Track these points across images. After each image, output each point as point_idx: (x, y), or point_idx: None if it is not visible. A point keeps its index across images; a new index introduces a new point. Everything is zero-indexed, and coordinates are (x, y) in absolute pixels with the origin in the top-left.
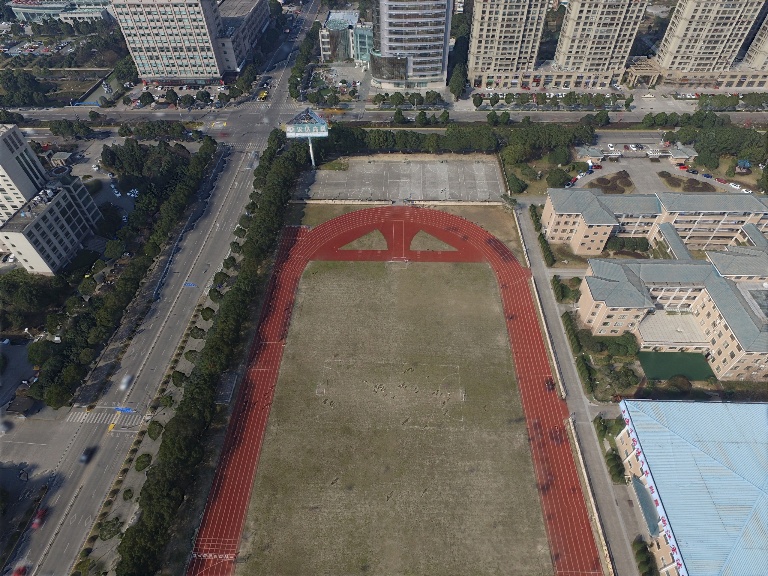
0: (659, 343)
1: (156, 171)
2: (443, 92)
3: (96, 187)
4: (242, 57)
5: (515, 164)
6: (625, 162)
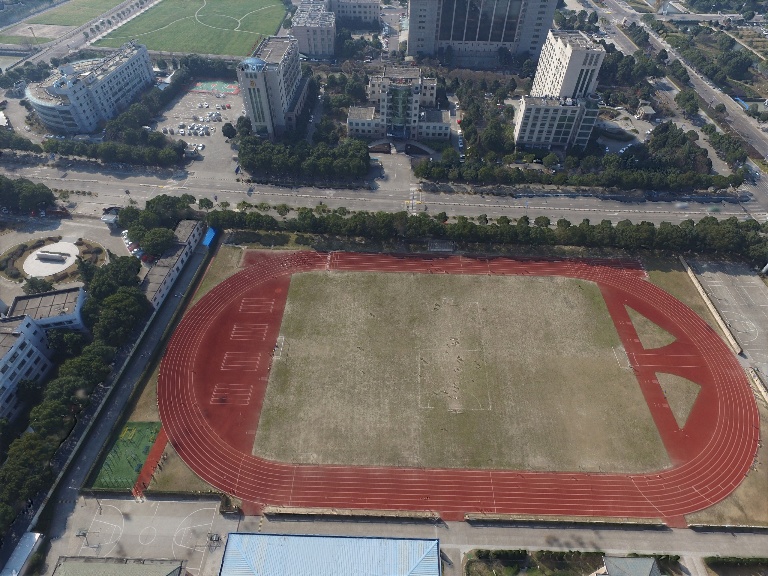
0: None
1: None
2: None
3: (624, 138)
4: None
5: None
6: None
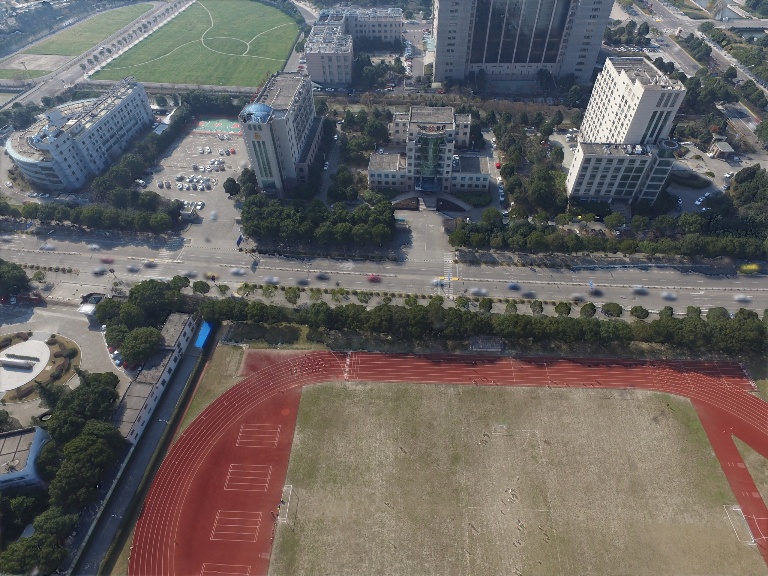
0: None
1: (747, 214)
2: None
3: (698, 184)
4: None
5: None
6: None
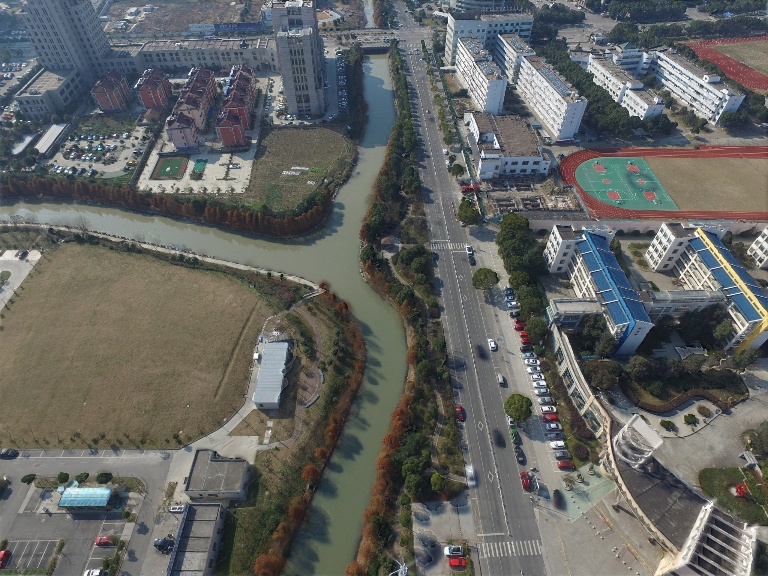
0: None
1: None
2: None
3: None
4: None
5: None
6: None
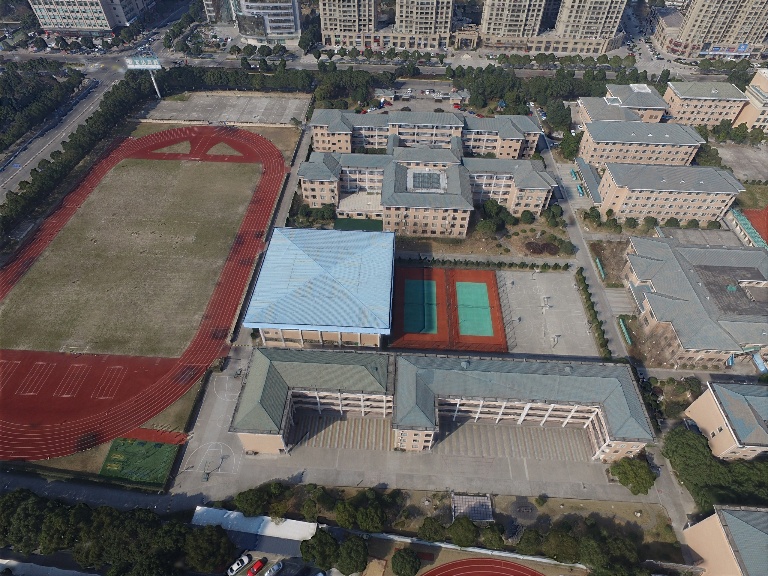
0: (347, 210)
1: (22, 93)
2: (298, 48)
3: None
4: (134, 14)
5: (323, 100)
6: (414, 102)
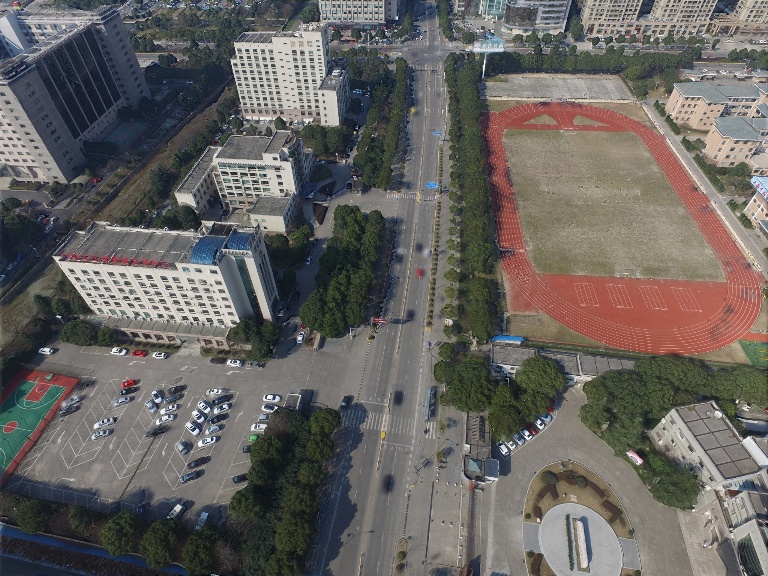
0: (765, 167)
1: (376, 75)
2: None
3: None
4: (397, 10)
5: (635, 80)
6: (719, 81)
